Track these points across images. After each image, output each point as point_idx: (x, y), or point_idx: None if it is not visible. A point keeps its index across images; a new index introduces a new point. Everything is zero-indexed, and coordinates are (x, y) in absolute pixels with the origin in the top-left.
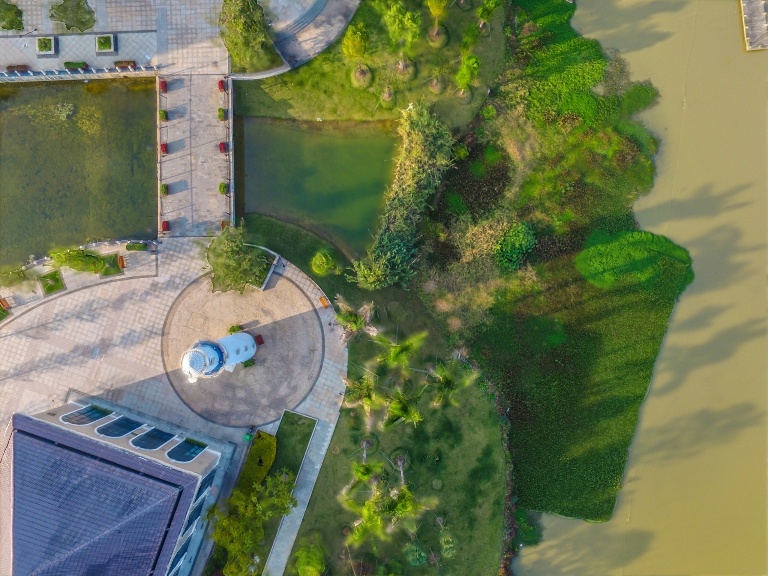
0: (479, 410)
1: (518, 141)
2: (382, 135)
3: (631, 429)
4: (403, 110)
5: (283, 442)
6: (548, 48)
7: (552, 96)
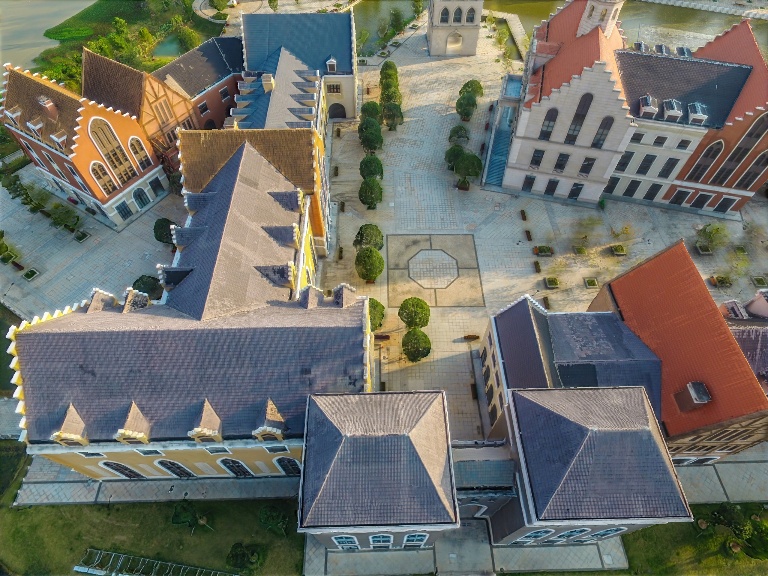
0: (153, 3)
1: None
2: None
3: (98, 1)
4: None
5: None
6: None
7: None
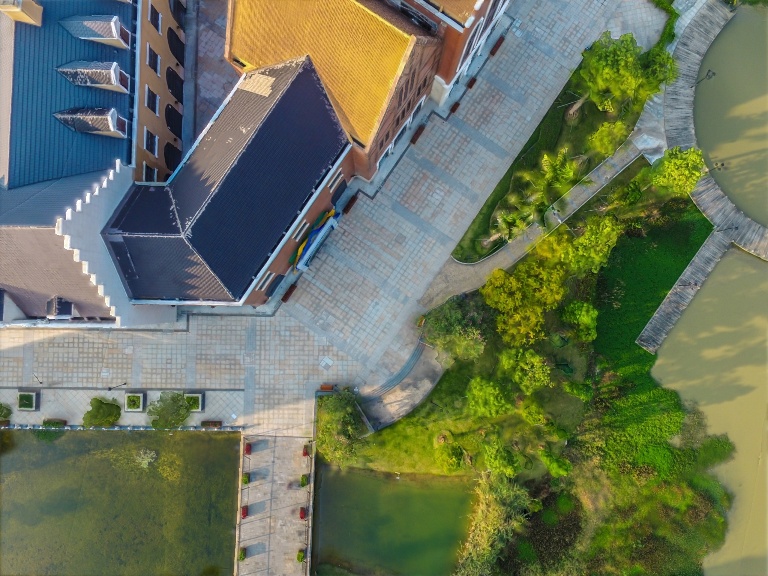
0: None
1: (592, 493)
2: (458, 488)
3: None
4: (482, 472)
5: None
6: (627, 399)
7: (628, 448)
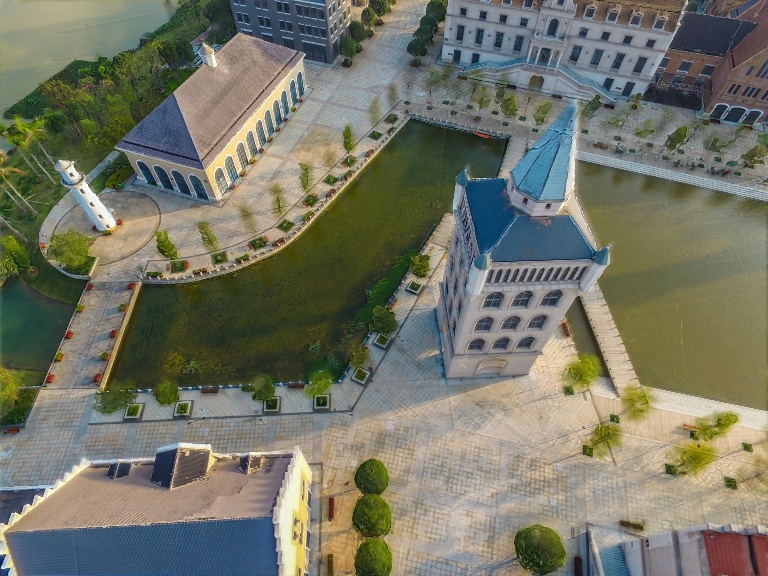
0: None
1: None
2: None
3: None
4: None
5: (103, 184)
6: None
7: None
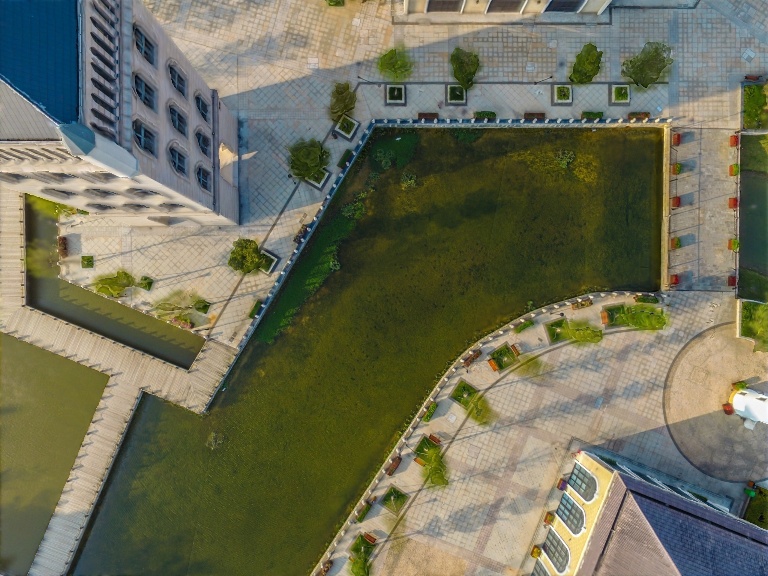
0: None
1: None
2: None
3: None
4: None
5: None
6: None
7: None
